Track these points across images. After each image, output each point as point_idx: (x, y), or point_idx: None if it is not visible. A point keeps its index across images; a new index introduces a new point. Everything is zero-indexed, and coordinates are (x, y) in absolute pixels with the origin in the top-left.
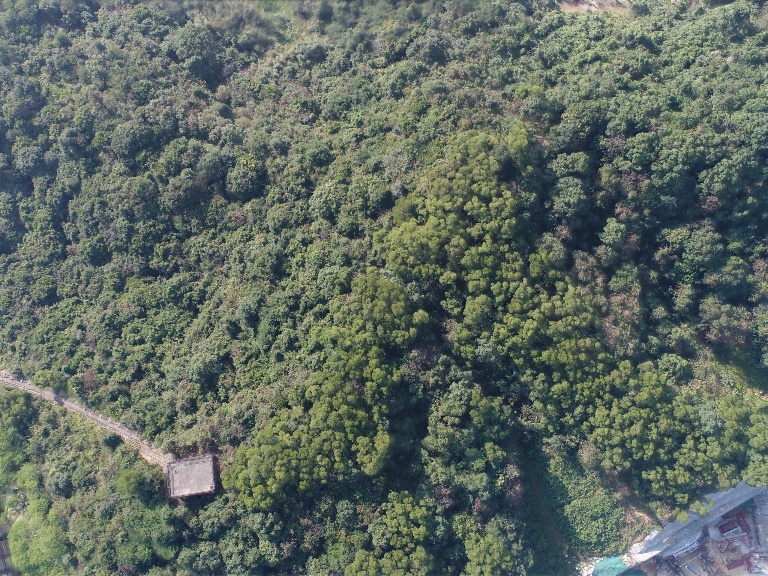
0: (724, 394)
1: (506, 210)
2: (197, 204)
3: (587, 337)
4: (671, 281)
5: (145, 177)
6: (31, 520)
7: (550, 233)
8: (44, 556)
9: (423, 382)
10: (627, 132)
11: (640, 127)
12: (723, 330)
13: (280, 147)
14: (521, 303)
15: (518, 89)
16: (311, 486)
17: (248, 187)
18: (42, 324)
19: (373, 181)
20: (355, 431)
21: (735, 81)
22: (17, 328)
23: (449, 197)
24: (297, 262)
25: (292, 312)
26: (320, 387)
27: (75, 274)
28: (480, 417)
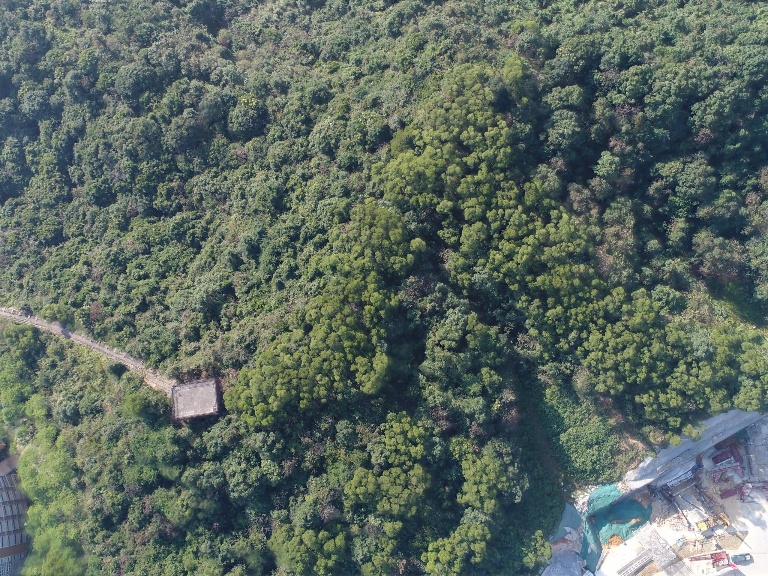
0: (716, 323)
1: (501, 139)
2: (199, 143)
3: (581, 264)
4: (665, 216)
5: (148, 118)
6: (40, 446)
7: (545, 164)
8: (53, 480)
9: (421, 308)
10: (621, 66)
11: (633, 60)
12: (716, 263)
13: (280, 86)
14: (516, 230)
15: (513, 25)
16: (311, 405)
17: (249, 125)
18: (49, 262)
19: (371, 116)
20: (354, 352)
21: (728, 17)
22: (24, 266)
23: (445, 127)
24: (297, 196)
25: (292, 242)
26: (320, 310)
27: (81, 215)
28: (476, 342)
